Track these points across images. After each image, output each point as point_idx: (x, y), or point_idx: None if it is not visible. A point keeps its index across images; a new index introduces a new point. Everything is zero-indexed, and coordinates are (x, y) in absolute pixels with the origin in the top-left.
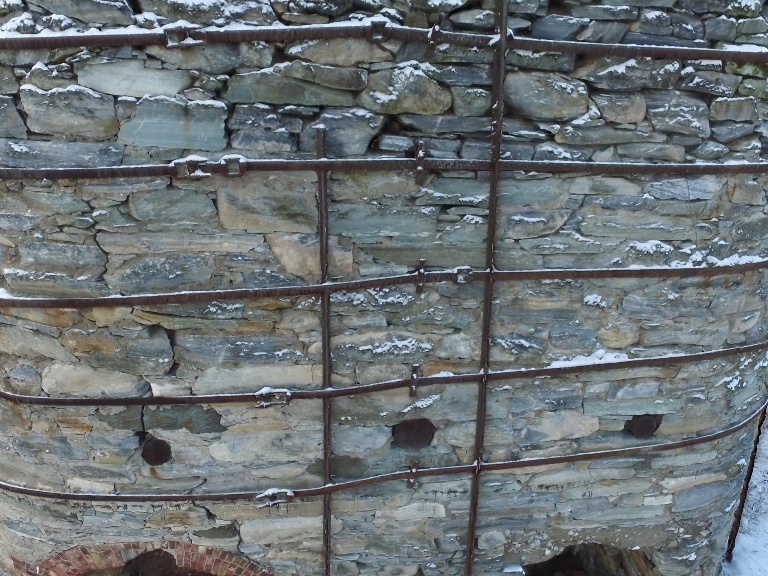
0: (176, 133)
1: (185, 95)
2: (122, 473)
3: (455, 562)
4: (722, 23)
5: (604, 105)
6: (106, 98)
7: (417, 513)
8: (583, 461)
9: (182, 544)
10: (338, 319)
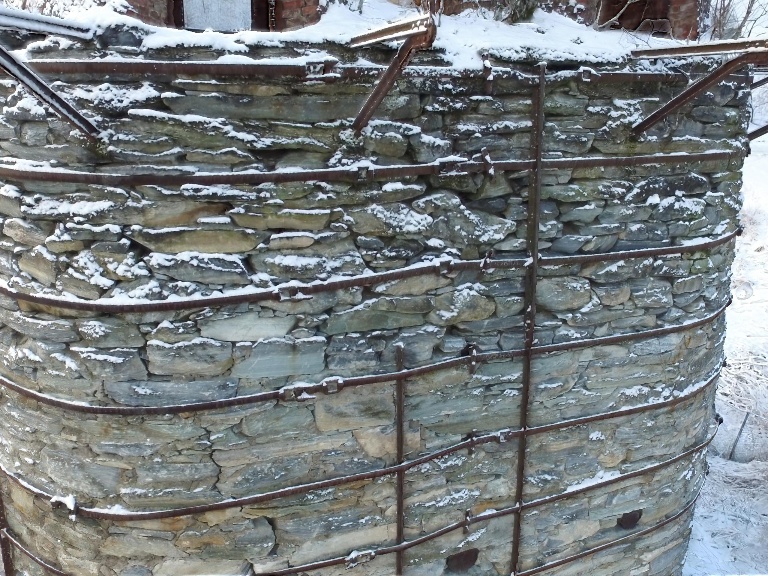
0: (284, 365)
1: (293, 335)
2: None
3: None
4: (680, 227)
5: (603, 295)
6: (225, 345)
7: None
8: (588, 555)
9: None
10: (408, 485)
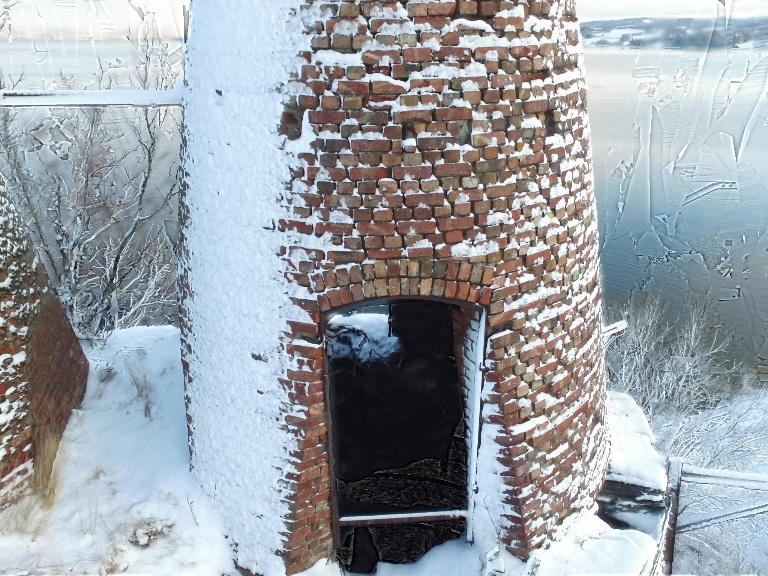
0: None
1: None
2: None
3: None
4: None
5: None
6: None
7: None
8: None
9: None
10: None
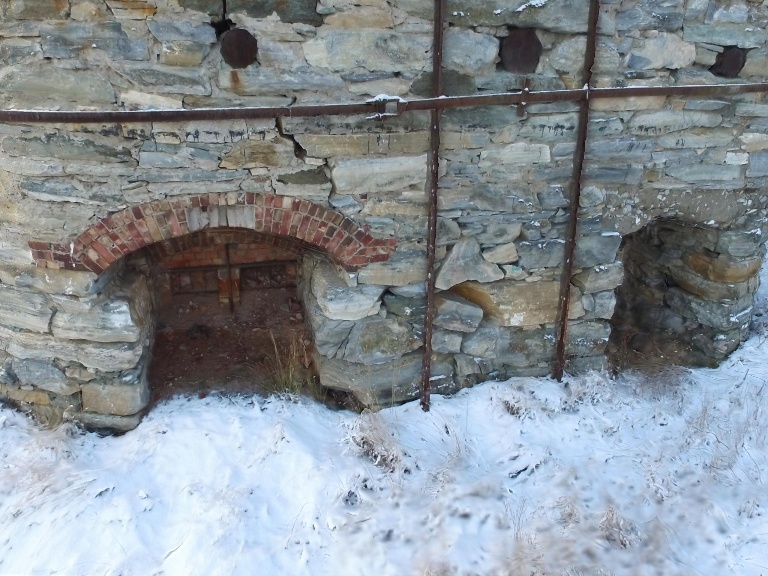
0: None
1: None
2: (195, 79)
3: (557, 222)
4: None
5: None
6: None
7: (523, 154)
8: (679, 99)
9: (263, 196)
10: None
